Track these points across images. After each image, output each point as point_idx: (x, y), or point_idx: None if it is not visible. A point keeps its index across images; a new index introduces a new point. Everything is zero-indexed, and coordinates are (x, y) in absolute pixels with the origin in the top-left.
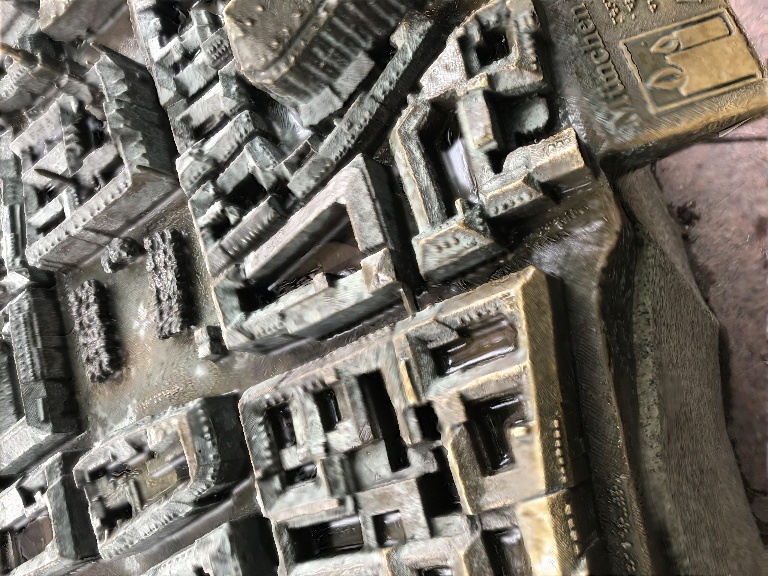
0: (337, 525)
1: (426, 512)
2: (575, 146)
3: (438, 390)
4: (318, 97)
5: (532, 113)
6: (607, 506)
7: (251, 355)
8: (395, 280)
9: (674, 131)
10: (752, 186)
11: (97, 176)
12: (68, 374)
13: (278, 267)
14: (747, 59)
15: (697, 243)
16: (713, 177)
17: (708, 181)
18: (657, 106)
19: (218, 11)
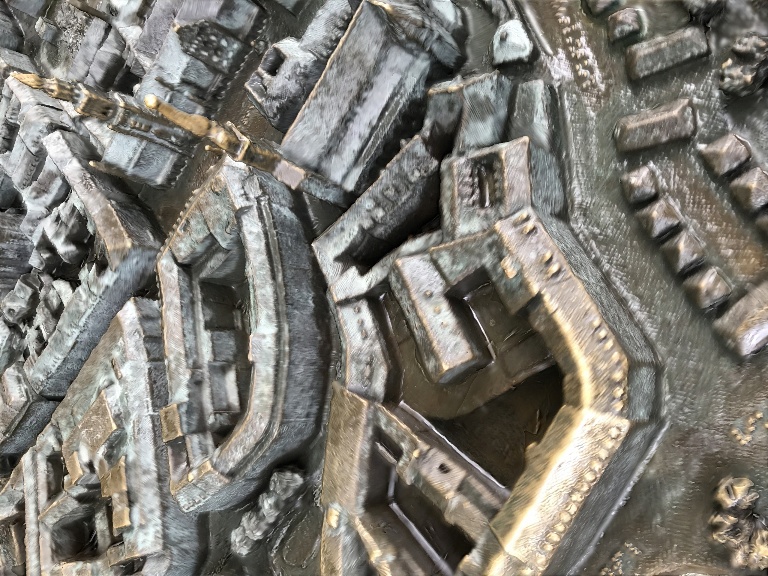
0: None
1: None
2: None
3: None
4: None
5: None
6: None
7: None
8: None
9: None
10: None
11: None
12: None
13: None
14: None
15: None
16: None
17: None
18: None
19: None
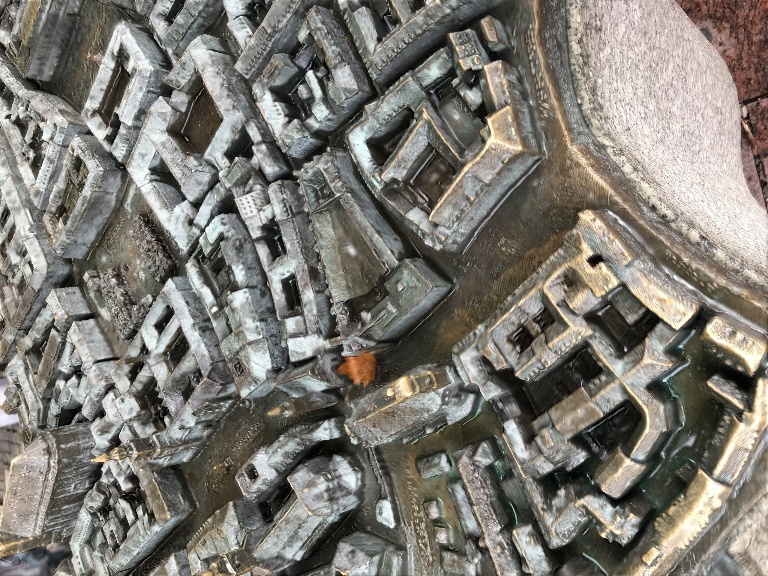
0: None
1: None
2: None
3: None
4: None
5: None
6: None
7: None
8: None
9: None
10: None
11: None
12: None
13: None
14: None
15: None
16: None
17: None
18: None
19: (141, 494)
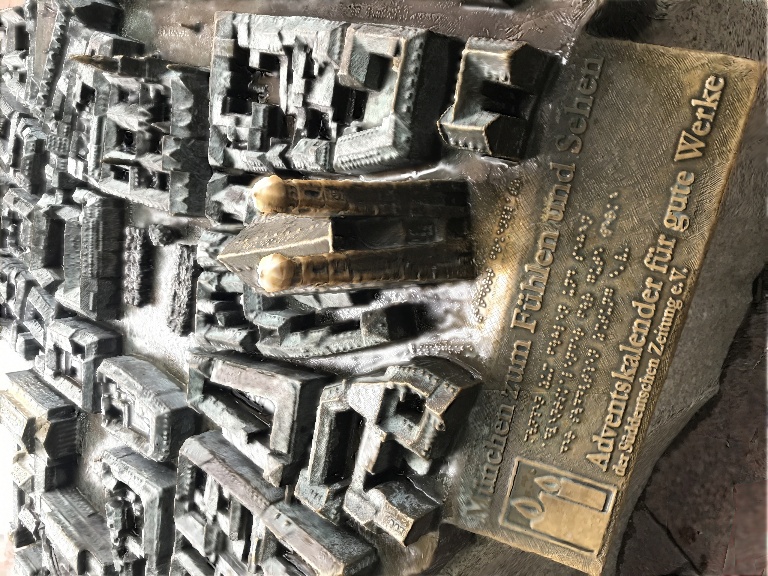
0: None
1: None
2: (402, 540)
3: (269, 567)
4: None
5: (419, 460)
6: None
7: None
8: (278, 487)
9: (505, 542)
10: None
11: (155, 172)
12: (118, 274)
13: None
14: (594, 540)
15: (760, 317)
16: None
17: None
18: (507, 520)
19: None
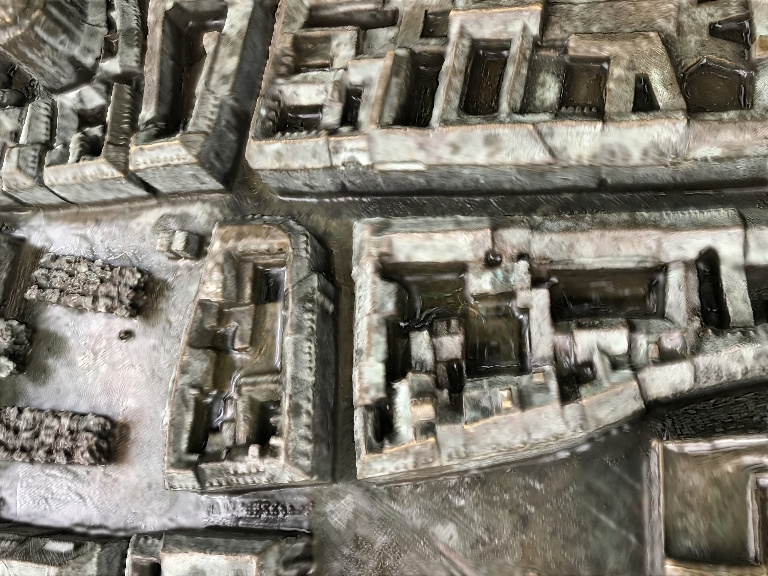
0: (418, 114)
1: None
2: None
3: None
4: (84, 35)
5: None
6: None
7: (223, 209)
8: None
9: None
10: None
11: None
12: None
13: (171, 105)
14: None
15: None
16: None
17: None
18: None
19: None
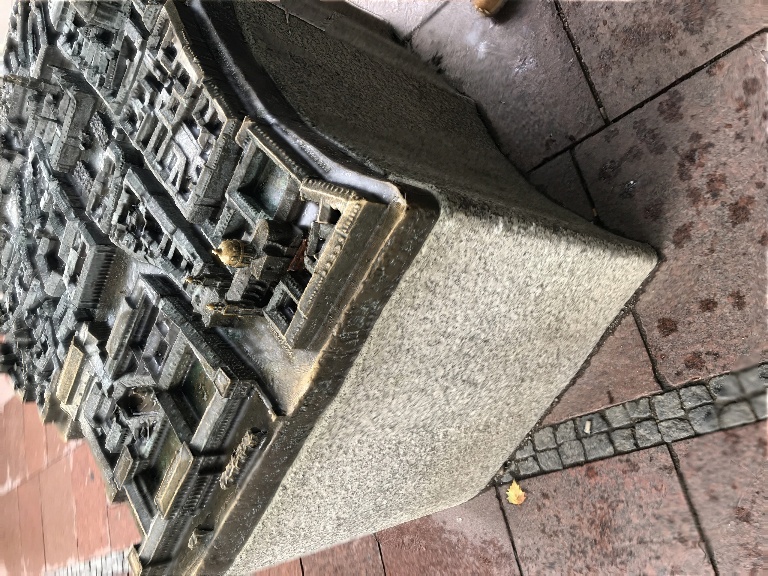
0: None
1: (168, 92)
2: None
3: None
4: (118, 18)
5: None
6: (218, 54)
7: None
8: (143, 40)
9: None
10: (457, 22)
11: None
12: (84, 207)
13: None
14: None
15: (447, 69)
16: (440, 32)
17: (439, 35)
18: None
19: None
